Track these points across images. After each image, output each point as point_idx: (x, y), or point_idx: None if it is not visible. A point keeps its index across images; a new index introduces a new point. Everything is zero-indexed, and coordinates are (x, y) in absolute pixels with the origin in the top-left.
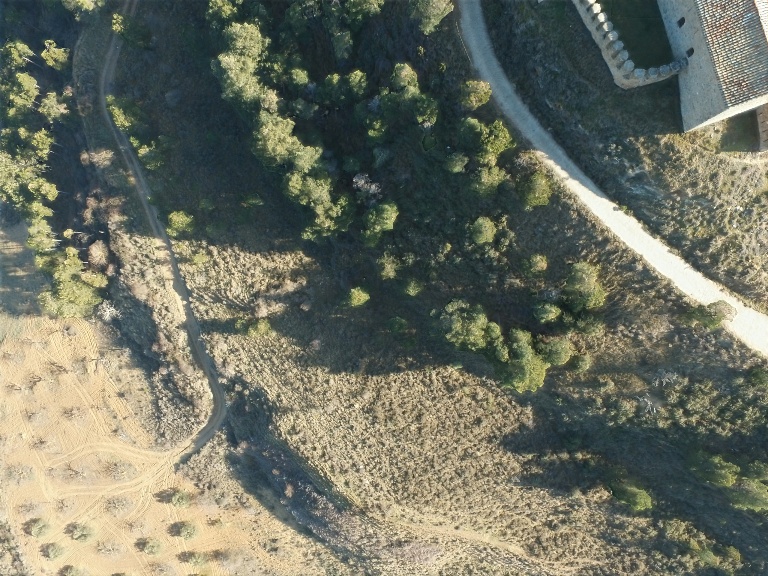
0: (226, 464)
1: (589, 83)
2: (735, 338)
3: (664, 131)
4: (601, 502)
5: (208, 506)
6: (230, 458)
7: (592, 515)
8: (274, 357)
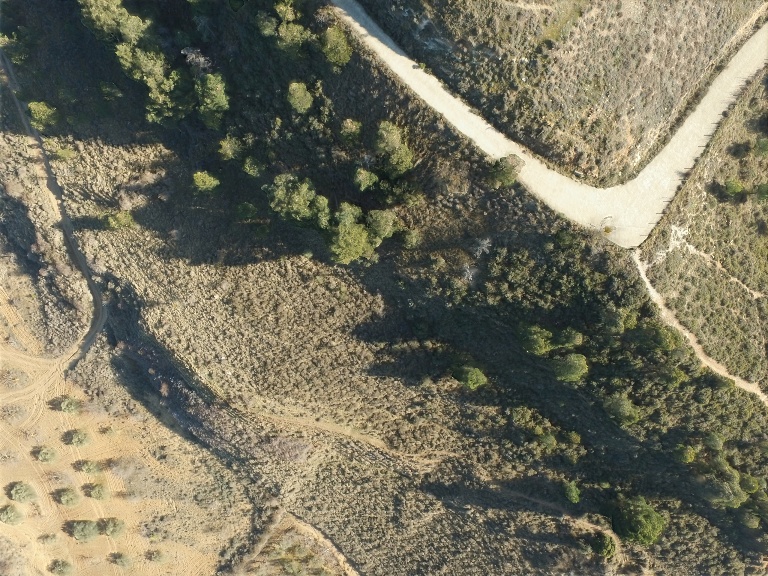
0: (112, 370)
1: None
2: (538, 199)
3: None
4: (451, 390)
5: (99, 414)
6: (116, 363)
7: (446, 406)
8: (140, 251)
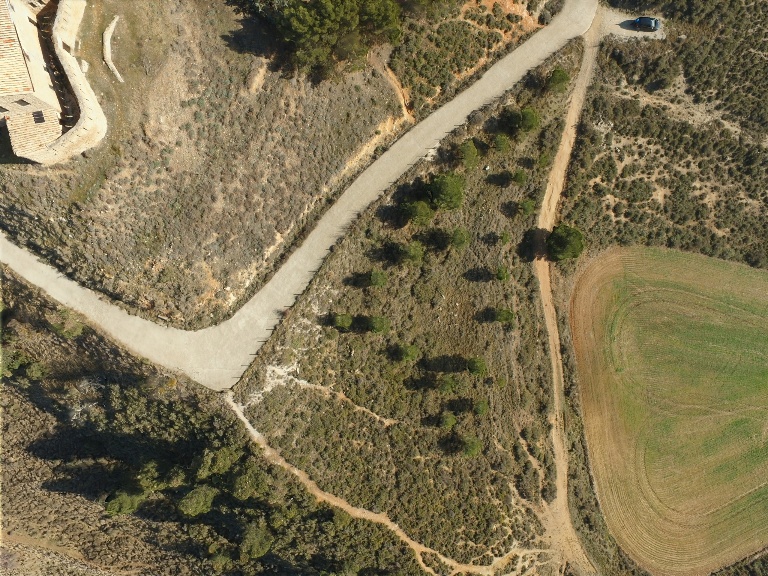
0: None
1: None
2: (117, 346)
3: None
4: None
5: None
6: None
7: (133, 519)
8: None
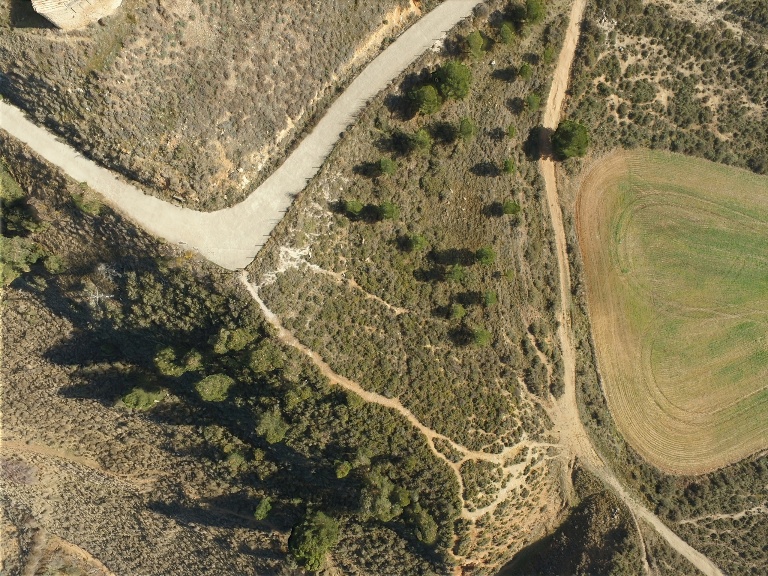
0: None
1: None
2: (134, 225)
3: None
4: (146, 411)
5: None
6: None
7: (148, 426)
8: None
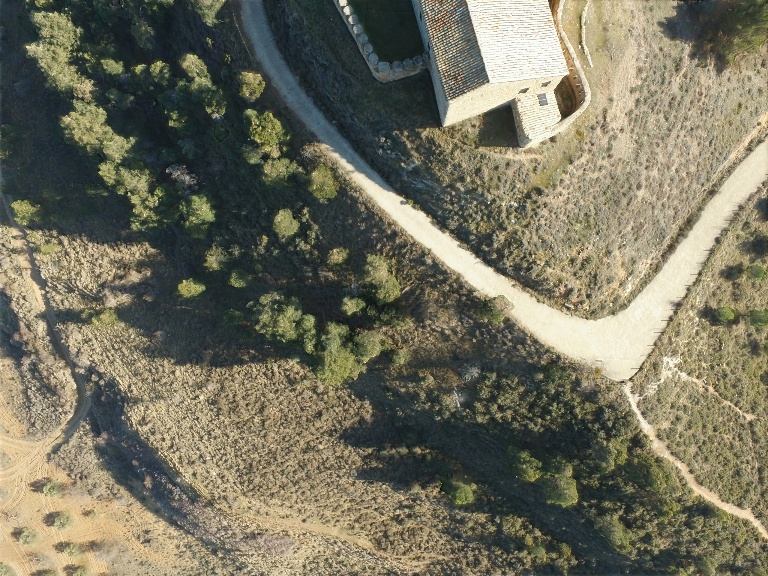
0: (96, 455)
1: (351, 76)
2: (527, 333)
3: (424, 125)
4: (440, 497)
5: (82, 496)
6: (99, 449)
7: (435, 510)
8: (124, 347)
